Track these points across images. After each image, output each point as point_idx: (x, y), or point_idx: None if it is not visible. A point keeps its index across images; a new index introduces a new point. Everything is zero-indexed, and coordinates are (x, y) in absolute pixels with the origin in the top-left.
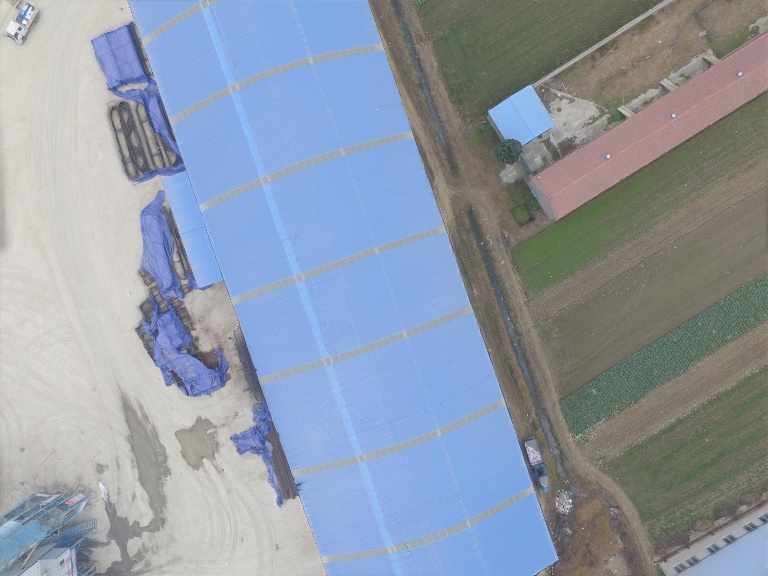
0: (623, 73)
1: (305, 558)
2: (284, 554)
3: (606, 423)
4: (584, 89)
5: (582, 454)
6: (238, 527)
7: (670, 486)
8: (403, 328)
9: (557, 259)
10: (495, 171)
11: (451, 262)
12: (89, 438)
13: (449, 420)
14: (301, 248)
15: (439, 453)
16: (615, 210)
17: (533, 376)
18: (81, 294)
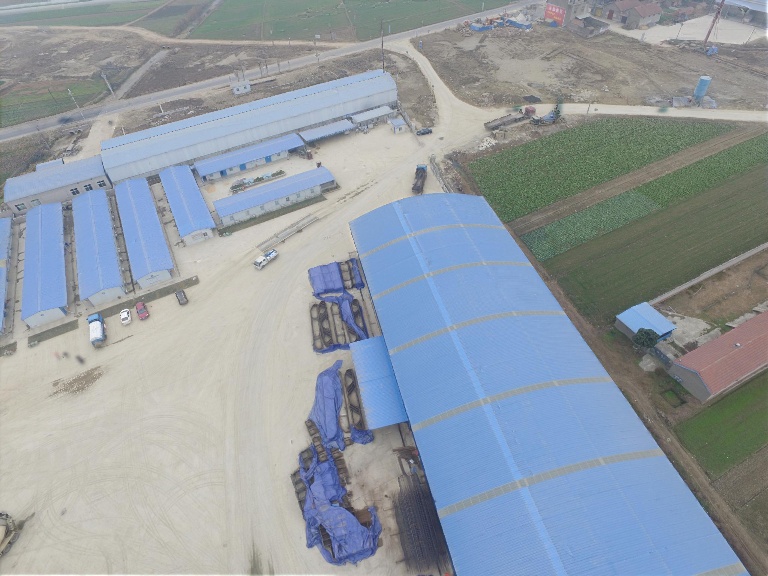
0: (717, 302)
1: None
2: None
3: None
4: (689, 311)
5: None
6: None
7: None
8: (598, 454)
9: (726, 440)
10: (634, 362)
11: (627, 406)
12: None
13: (684, 572)
14: (486, 376)
15: None
16: (765, 399)
17: None
18: (245, 440)
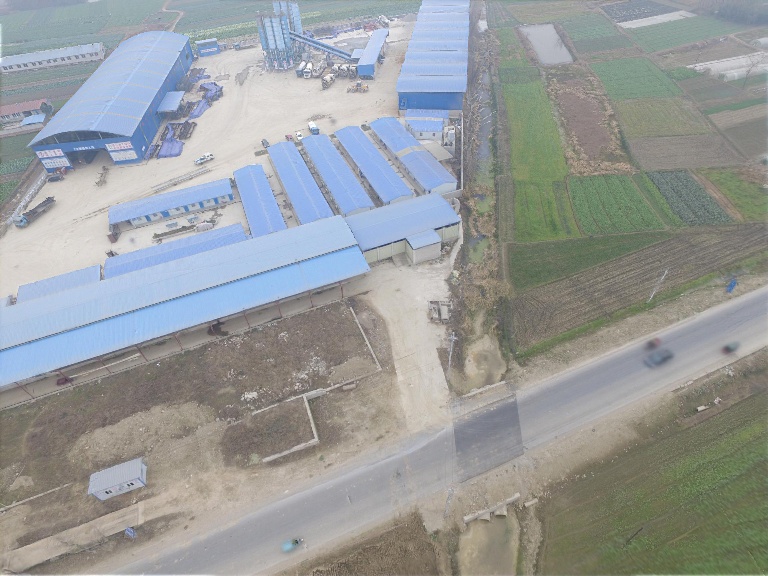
0: None
1: None
2: None
3: (88, 77)
4: None
5: None
6: None
7: (84, 68)
8: None
9: (63, 102)
10: None
11: None
12: None
13: None
14: None
15: None
16: None
17: None
18: (239, 103)
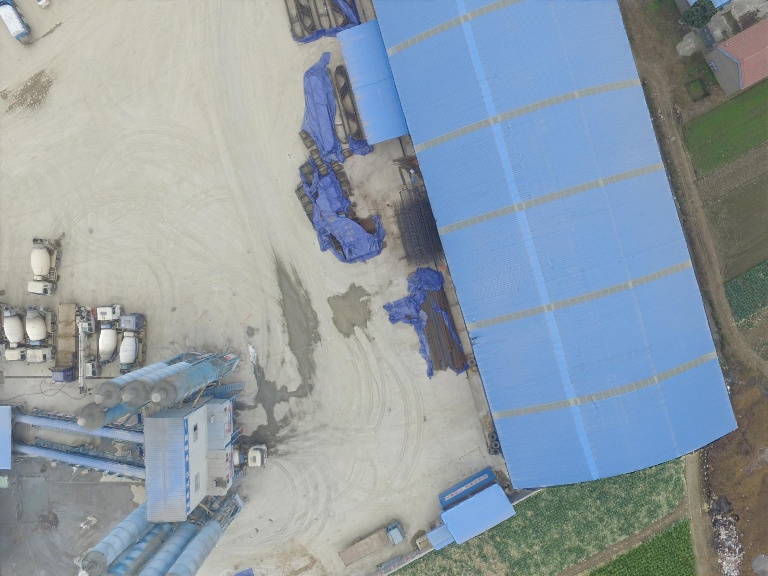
0: None
1: (453, 431)
2: (432, 426)
3: None
4: None
5: (745, 339)
6: (386, 397)
7: None
8: (600, 176)
9: (731, 137)
10: (671, 43)
11: (645, 116)
12: (241, 300)
13: (641, 273)
14: (500, 89)
15: (630, 305)
16: None
17: (698, 257)
18: (240, 155)
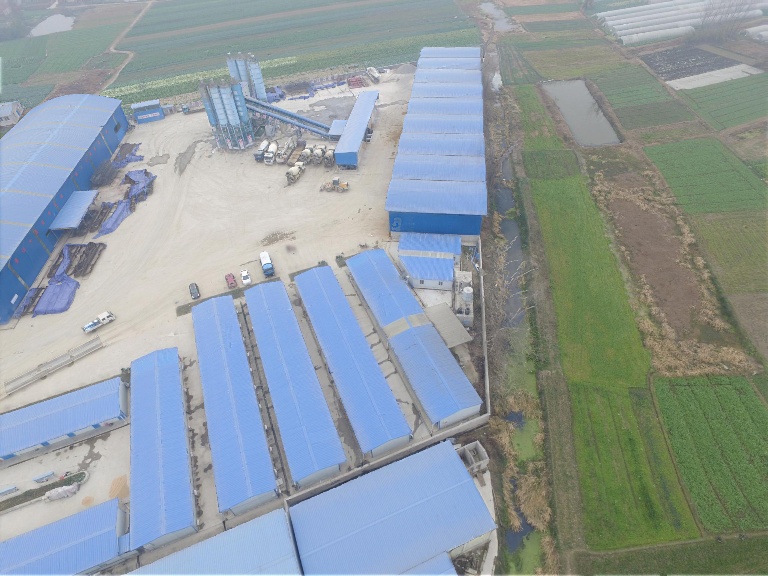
0: None
1: None
2: None
3: None
4: None
5: None
6: None
7: None
8: None
9: None
10: None
11: None
12: None
13: None
14: None
15: None
16: None
17: None
18: (172, 207)
